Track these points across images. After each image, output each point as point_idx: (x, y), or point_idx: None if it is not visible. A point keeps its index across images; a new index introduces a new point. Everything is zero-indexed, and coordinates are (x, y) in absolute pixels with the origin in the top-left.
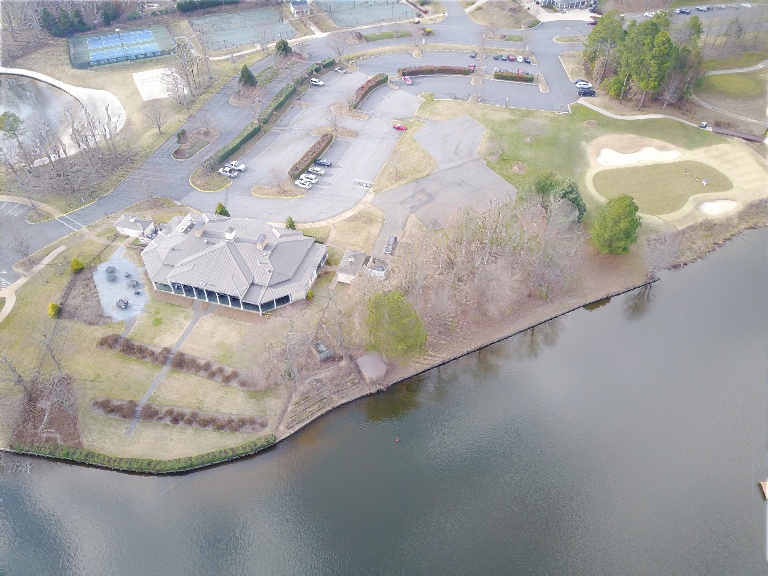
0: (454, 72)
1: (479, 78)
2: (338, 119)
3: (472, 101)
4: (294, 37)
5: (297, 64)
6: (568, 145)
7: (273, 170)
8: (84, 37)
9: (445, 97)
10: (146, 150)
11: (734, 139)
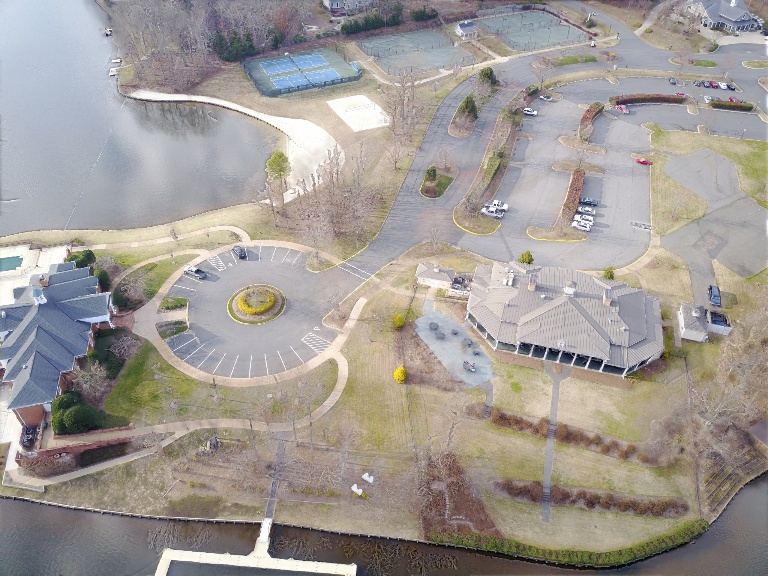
0: (666, 100)
1: (694, 107)
2: (585, 154)
3: (703, 132)
4: (474, 62)
5: (497, 91)
6: None
7: (537, 210)
8: (256, 61)
9: (671, 128)
10: (391, 187)
11: None
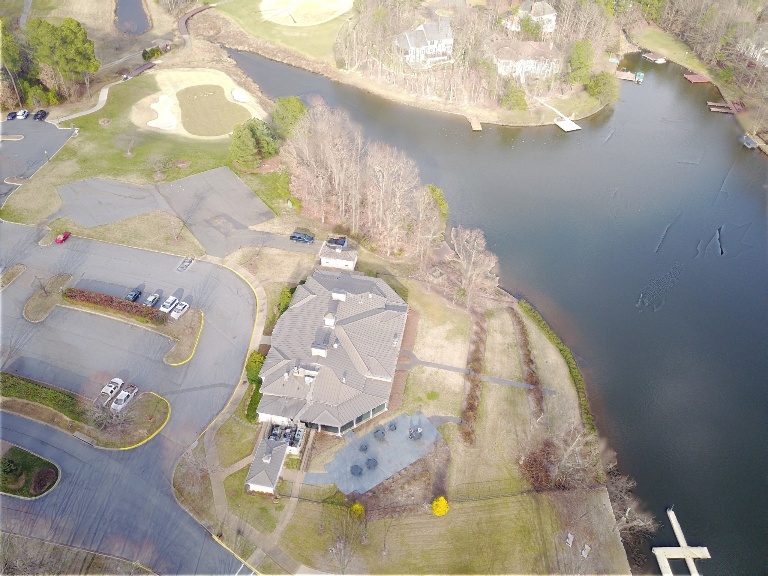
0: None
1: None
2: None
3: (23, 182)
4: None
5: None
6: (142, 137)
7: (130, 350)
8: None
9: None
10: None
11: (149, 72)
